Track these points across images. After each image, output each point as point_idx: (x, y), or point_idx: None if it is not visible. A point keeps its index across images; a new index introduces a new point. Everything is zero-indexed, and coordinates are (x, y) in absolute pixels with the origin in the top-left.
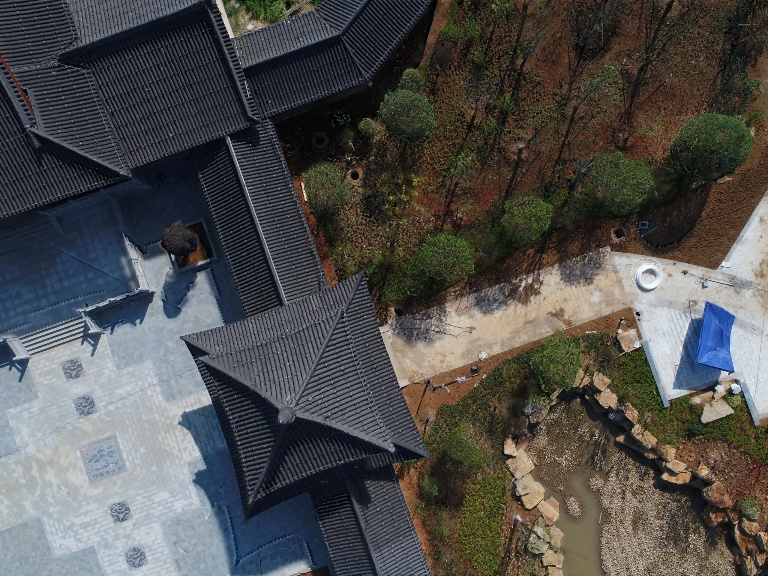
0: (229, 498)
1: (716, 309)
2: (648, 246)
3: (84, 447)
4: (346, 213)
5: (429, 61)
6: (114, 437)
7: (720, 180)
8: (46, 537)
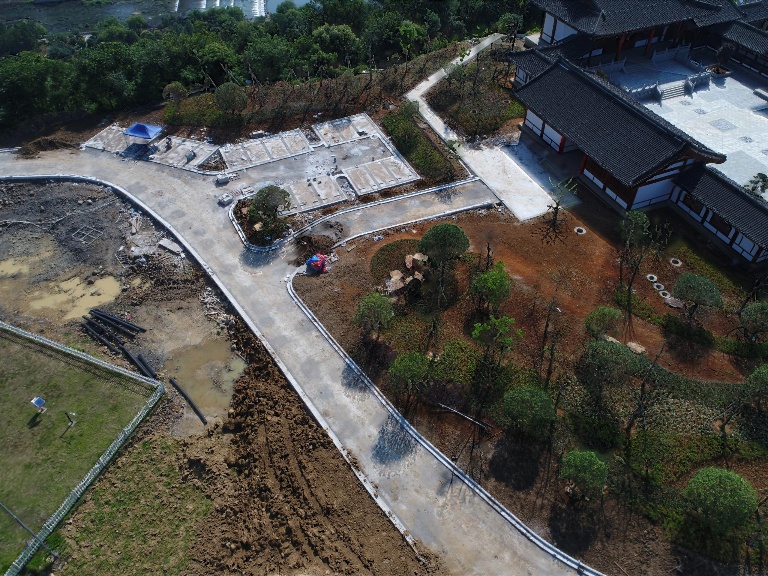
0: None
1: None
2: None
3: (710, 122)
4: None
5: None
6: (723, 119)
7: None
8: (712, 149)
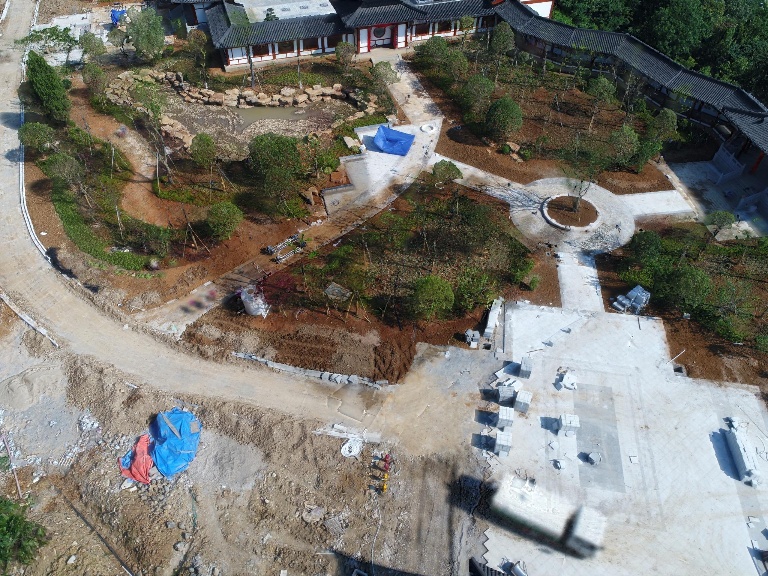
0: None
1: (410, 142)
2: (447, 130)
3: None
4: None
5: (536, 68)
6: None
7: None
8: None
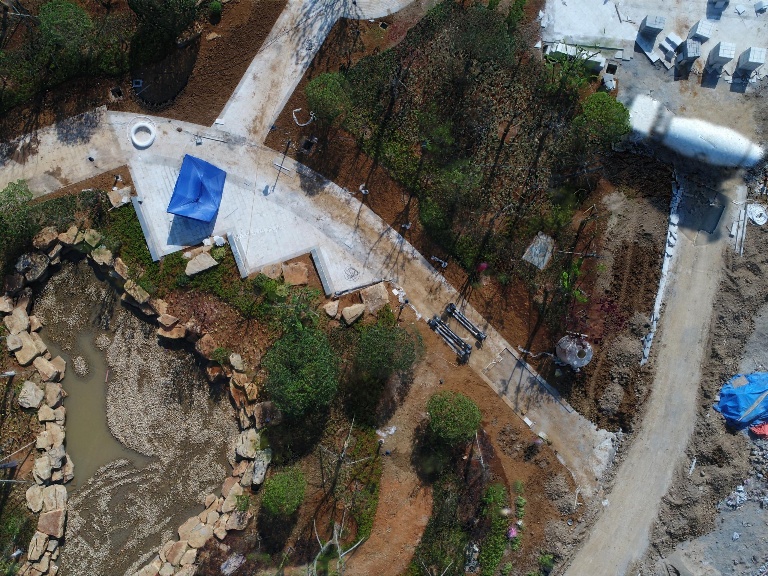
0: None
1: (199, 162)
2: (144, 104)
3: None
4: None
5: None
6: None
7: (208, 37)
8: None
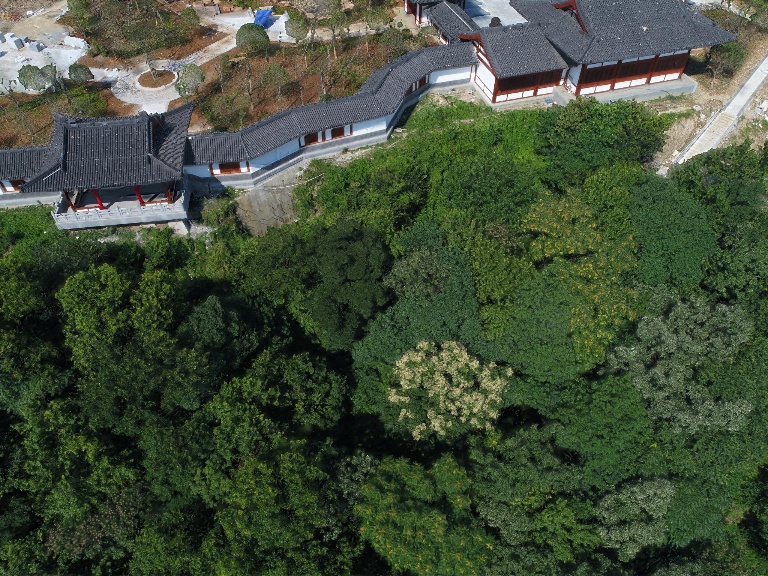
0: (468, 0)
1: None
2: None
3: None
4: None
5: None
6: None
7: None
8: None
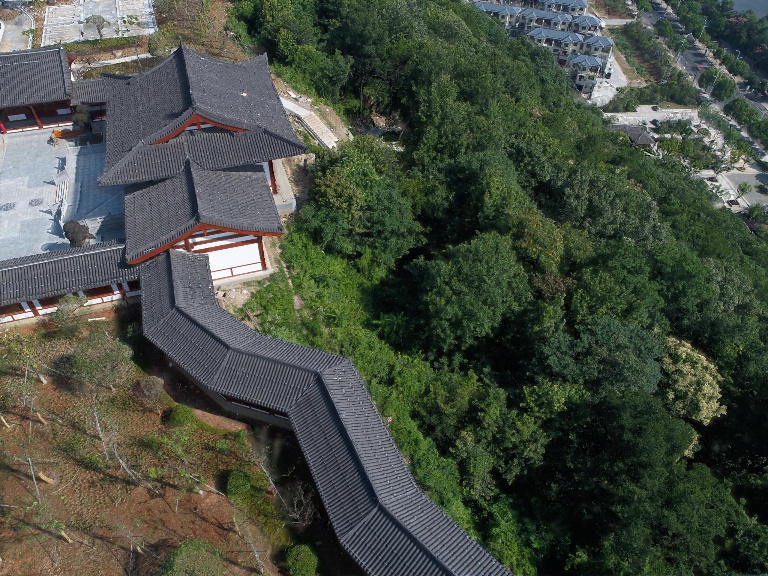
0: None
1: None
2: None
3: None
4: (64, 344)
5: None
6: None
7: None
8: None
